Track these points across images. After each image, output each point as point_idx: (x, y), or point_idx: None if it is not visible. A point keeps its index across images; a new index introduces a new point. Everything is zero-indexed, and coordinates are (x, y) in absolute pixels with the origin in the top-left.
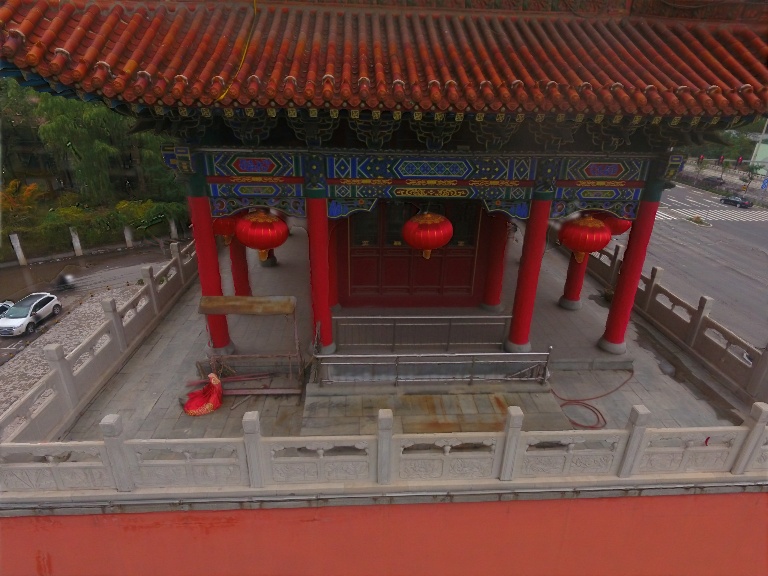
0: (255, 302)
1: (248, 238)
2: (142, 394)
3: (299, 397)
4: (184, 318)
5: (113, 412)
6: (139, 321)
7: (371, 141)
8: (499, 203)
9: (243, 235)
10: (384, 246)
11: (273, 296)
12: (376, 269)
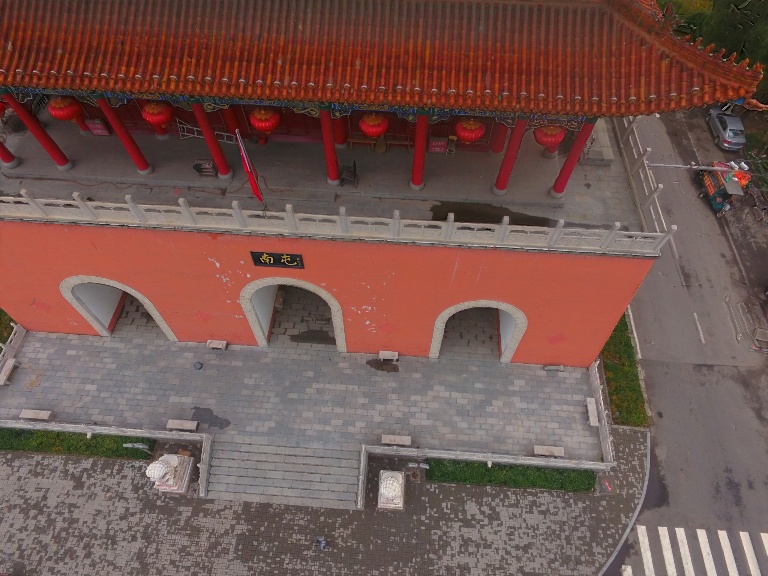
0: None
1: None
2: None
3: None
4: None
5: None
6: None
7: None
8: None
9: None
10: None
11: None
12: None
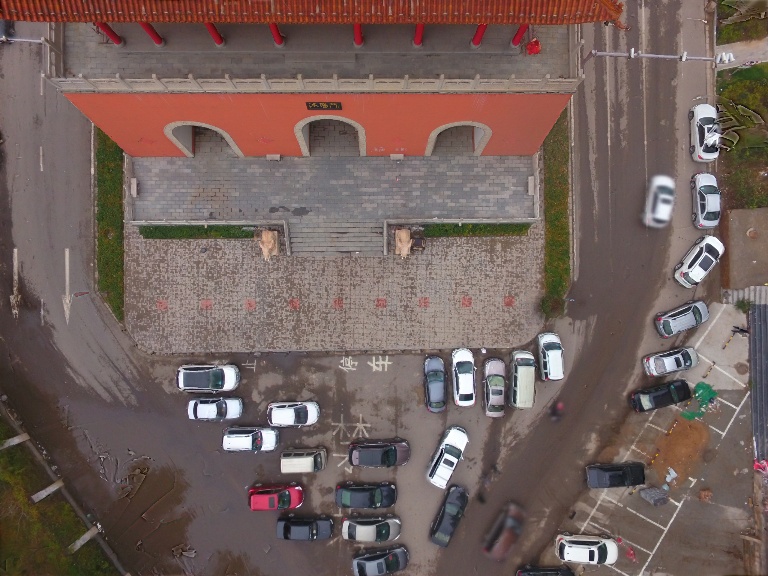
0: None
1: None
2: (529, 71)
3: None
4: (473, 76)
5: (539, 76)
6: None
7: None
8: None
9: None
10: None
11: None
12: None
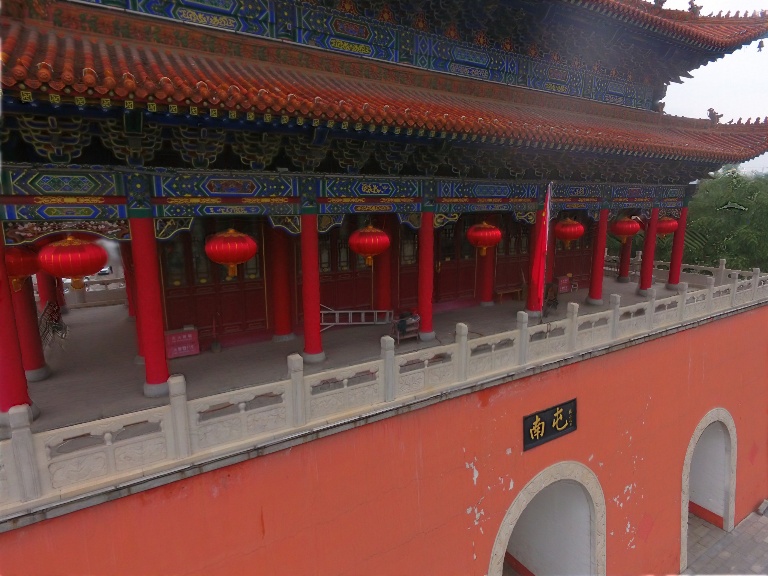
0: None
1: None
2: None
3: None
4: None
5: None
6: (108, 294)
7: None
8: None
9: None
10: None
11: None
12: None
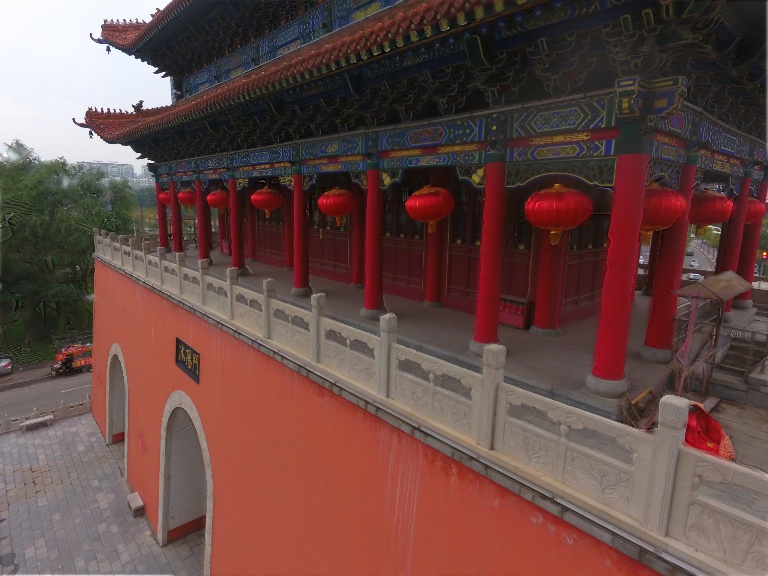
0: (729, 280)
1: (677, 209)
2: None
3: (726, 403)
4: None
5: None
6: None
7: (721, 109)
8: (733, 180)
9: (673, 206)
10: (584, 250)
11: (726, 272)
12: (578, 277)
